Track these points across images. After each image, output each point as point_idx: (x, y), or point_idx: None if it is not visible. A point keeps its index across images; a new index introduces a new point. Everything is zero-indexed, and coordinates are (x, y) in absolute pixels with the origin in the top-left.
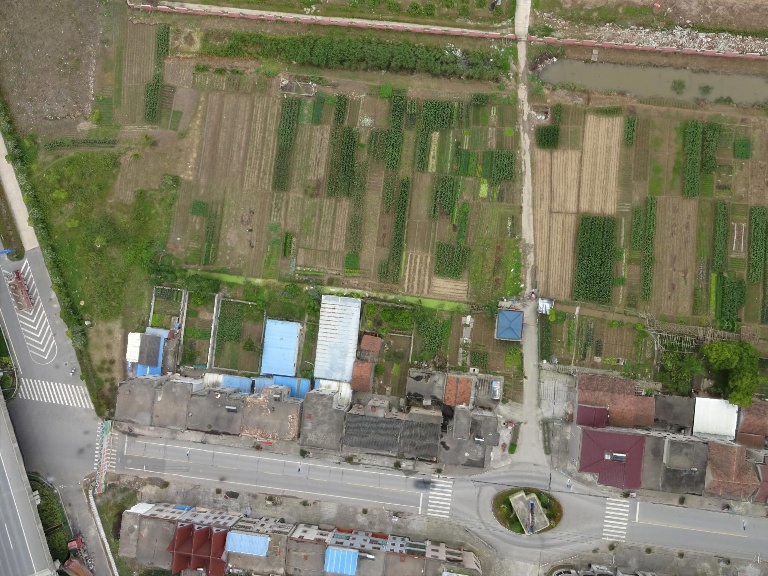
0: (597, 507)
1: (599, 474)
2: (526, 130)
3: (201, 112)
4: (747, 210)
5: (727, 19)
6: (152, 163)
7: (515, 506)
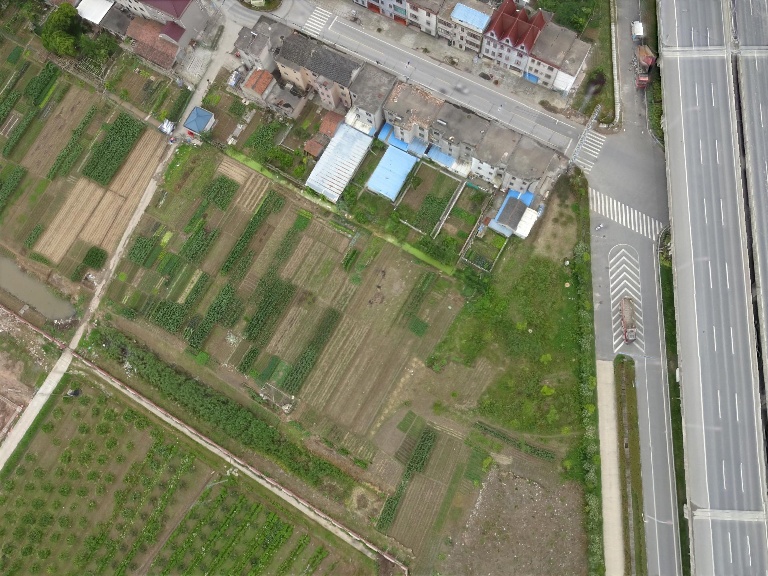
0: None
1: None
2: (109, 271)
3: (380, 420)
4: None
5: None
6: (446, 388)
7: None
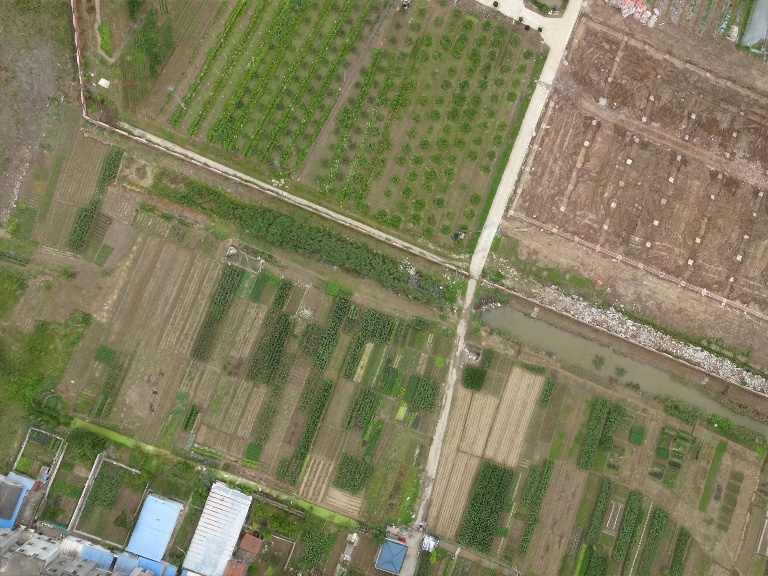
0: None
1: None
2: (456, 366)
3: (134, 253)
4: (627, 492)
5: (654, 314)
6: (64, 295)
7: None
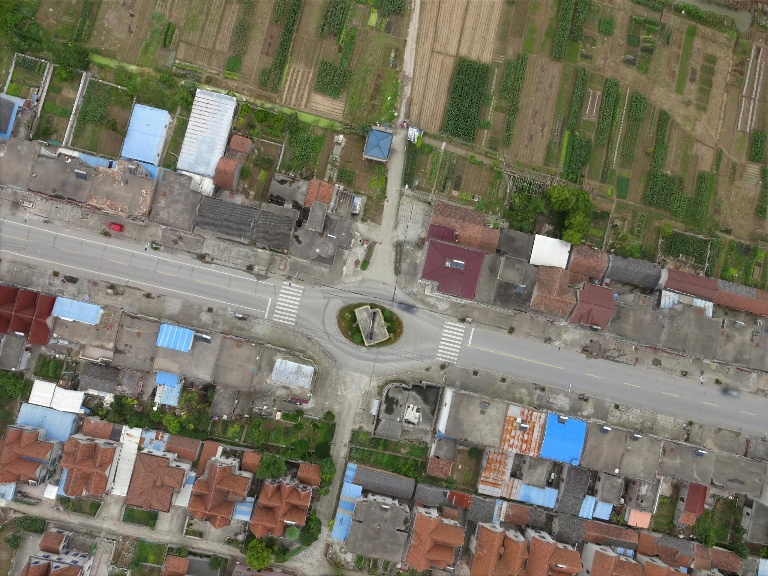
0: (435, 329)
1: (439, 283)
2: None
3: None
4: (603, 80)
5: None
6: None
7: (359, 316)
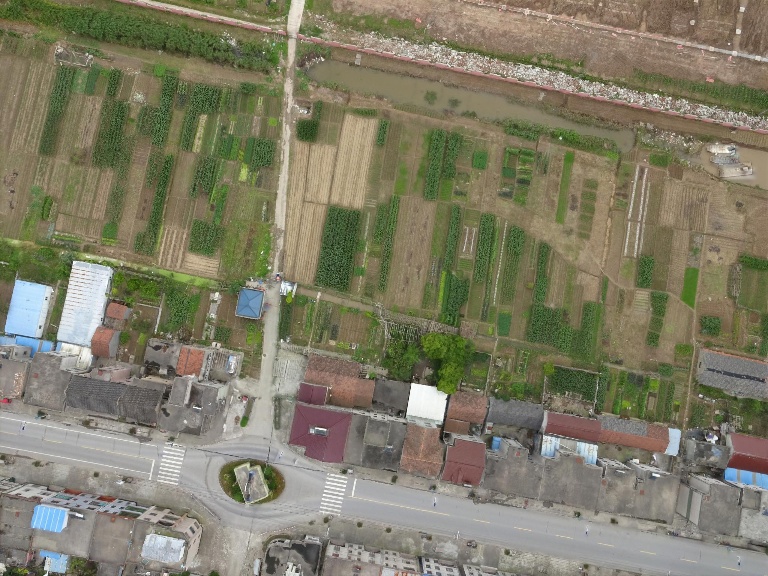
0: (318, 481)
1: (306, 447)
2: (288, 122)
3: None
4: (479, 216)
5: (478, 41)
6: None
7: (238, 476)
